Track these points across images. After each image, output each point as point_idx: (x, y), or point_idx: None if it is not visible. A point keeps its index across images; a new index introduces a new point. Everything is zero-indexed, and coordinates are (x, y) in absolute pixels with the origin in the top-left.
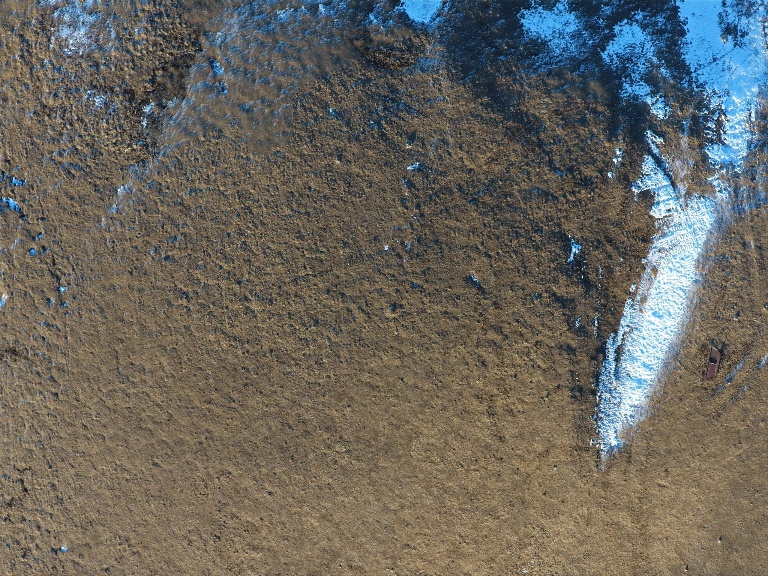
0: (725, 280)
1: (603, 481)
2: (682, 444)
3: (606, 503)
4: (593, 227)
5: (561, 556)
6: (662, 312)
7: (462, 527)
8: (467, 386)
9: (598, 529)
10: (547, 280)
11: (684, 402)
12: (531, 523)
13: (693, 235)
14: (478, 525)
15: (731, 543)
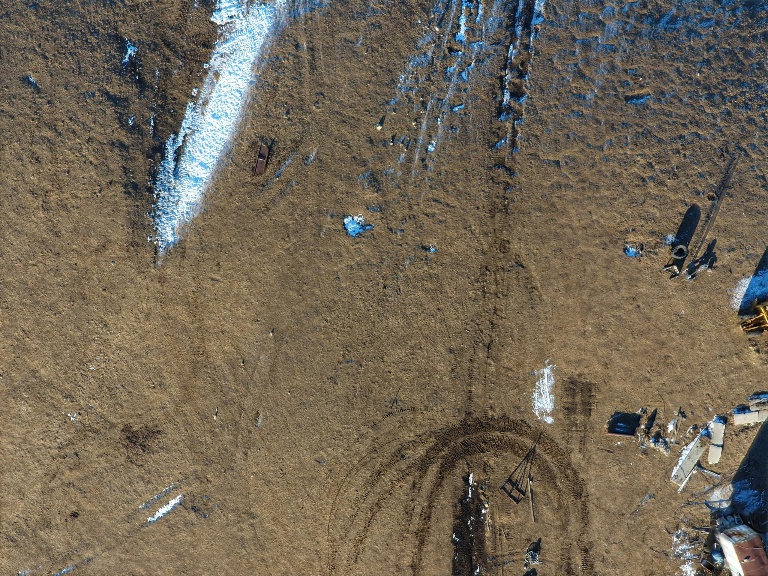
0: (277, 80)
1: (160, 276)
2: (233, 238)
3: (163, 298)
4: (151, 31)
5: (125, 352)
6: (220, 114)
7: (24, 322)
8: (22, 182)
9: (157, 324)
10: (100, 80)
11: (234, 197)
12: (94, 319)
13: (252, 40)
14: (40, 320)
15: (282, 335)
